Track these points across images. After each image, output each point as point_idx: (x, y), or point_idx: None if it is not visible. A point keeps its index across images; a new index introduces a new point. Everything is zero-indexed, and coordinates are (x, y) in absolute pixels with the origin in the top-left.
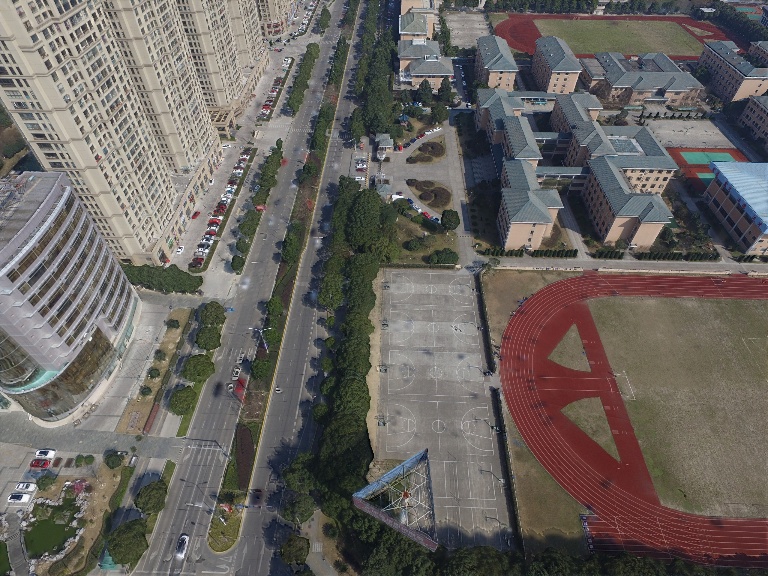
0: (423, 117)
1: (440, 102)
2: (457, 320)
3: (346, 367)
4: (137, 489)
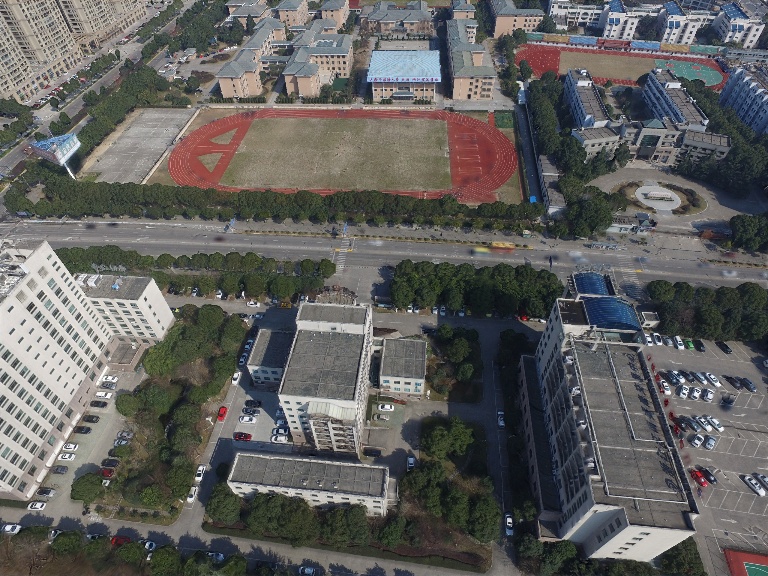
0: (231, 42)
1: (248, 33)
2: (171, 127)
3: None
4: None
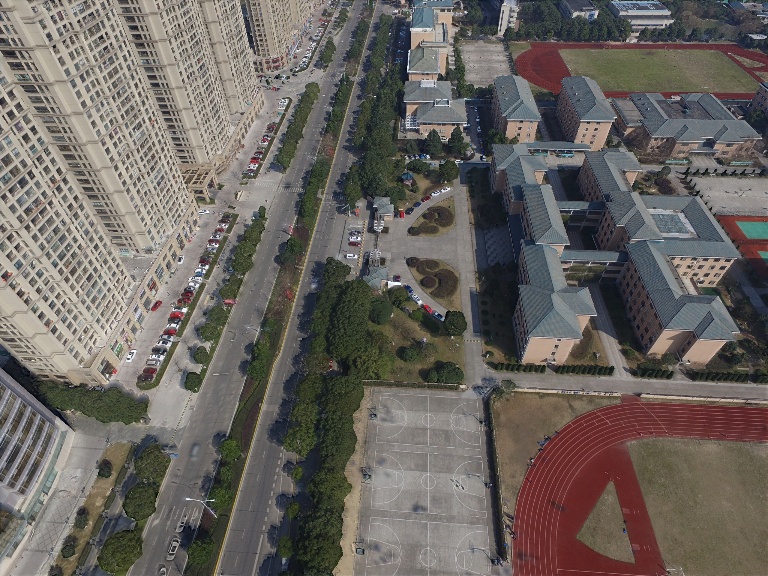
0: (430, 173)
1: (450, 154)
2: (459, 470)
3: (308, 561)
4: None
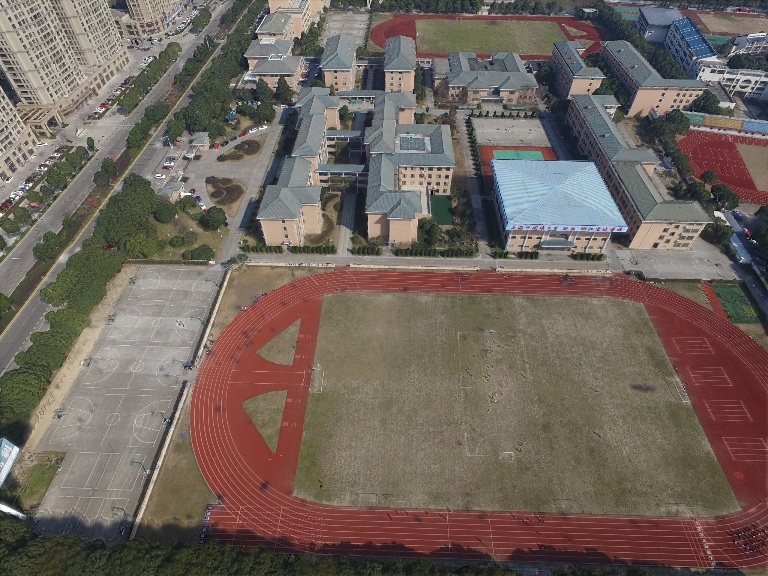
0: (256, 116)
1: (279, 101)
2: (185, 315)
3: None
4: None
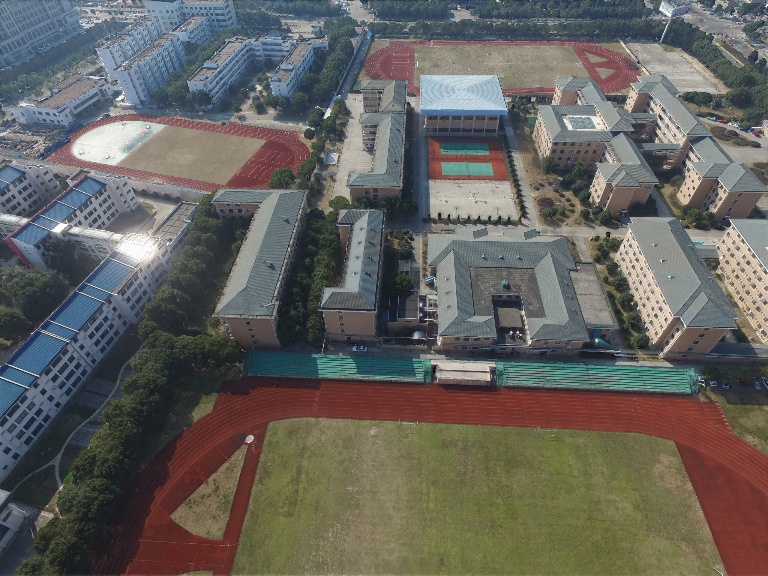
0: None
1: None
2: None
3: None
4: (762, 46)
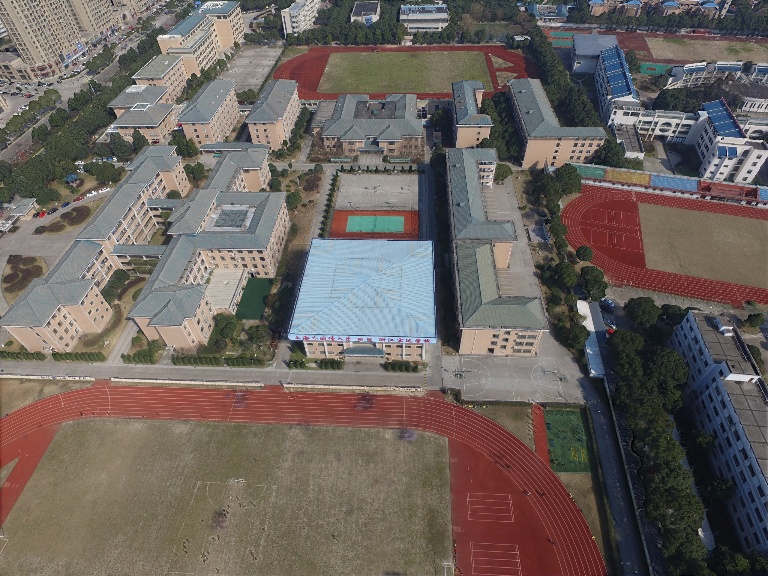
0: None
1: None
2: None
3: None
4: None
